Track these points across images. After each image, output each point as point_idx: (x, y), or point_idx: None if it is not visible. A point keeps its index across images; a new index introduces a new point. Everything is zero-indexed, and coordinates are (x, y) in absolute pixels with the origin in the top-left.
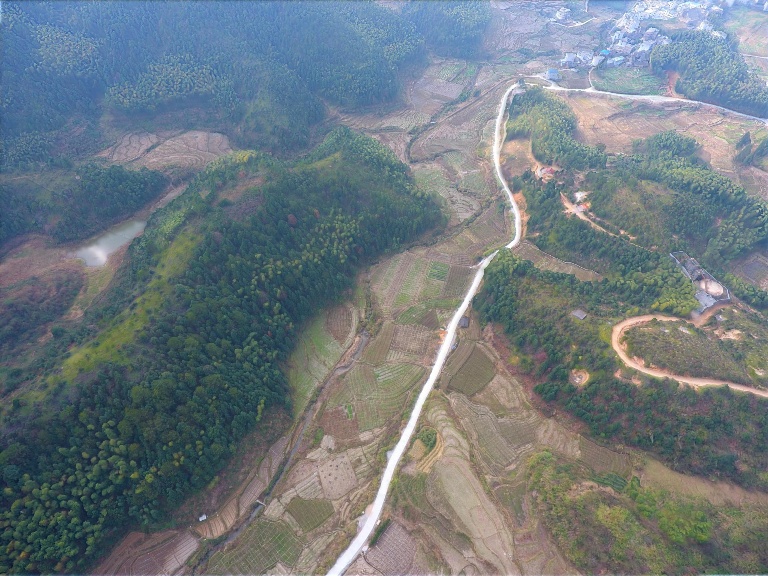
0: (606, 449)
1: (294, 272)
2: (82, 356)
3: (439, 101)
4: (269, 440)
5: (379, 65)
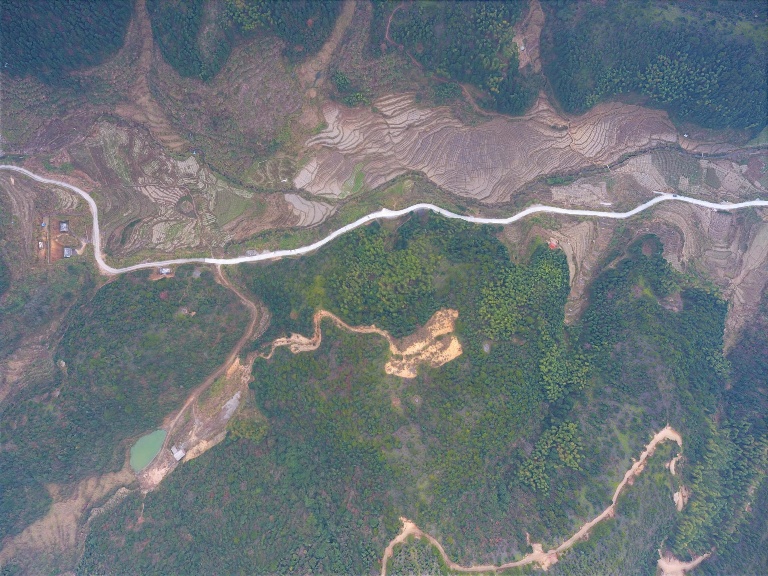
0: None
1: None
2: (748, 28)
3: None
4: (731, 140)
5: None
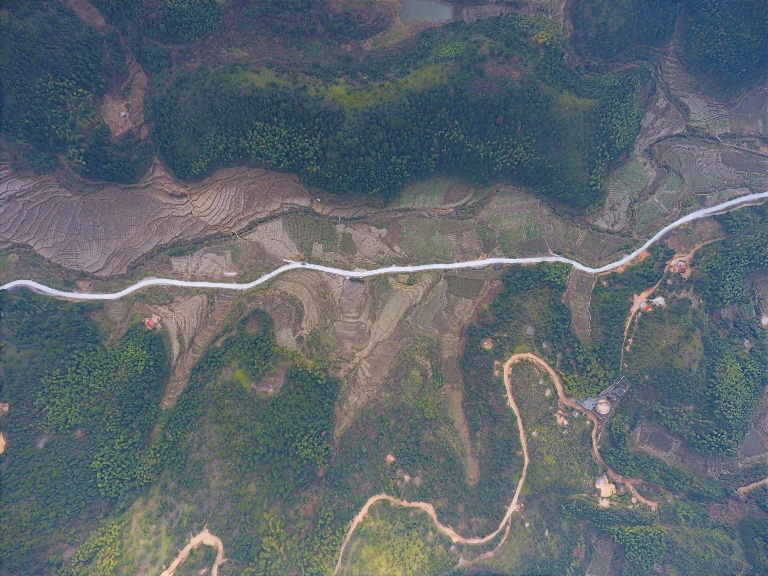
0: (456, 370)
1: (464, 148)
2: (340, 93)
3: (760, 125)
4: (367, 203)
5: (761, 46)
